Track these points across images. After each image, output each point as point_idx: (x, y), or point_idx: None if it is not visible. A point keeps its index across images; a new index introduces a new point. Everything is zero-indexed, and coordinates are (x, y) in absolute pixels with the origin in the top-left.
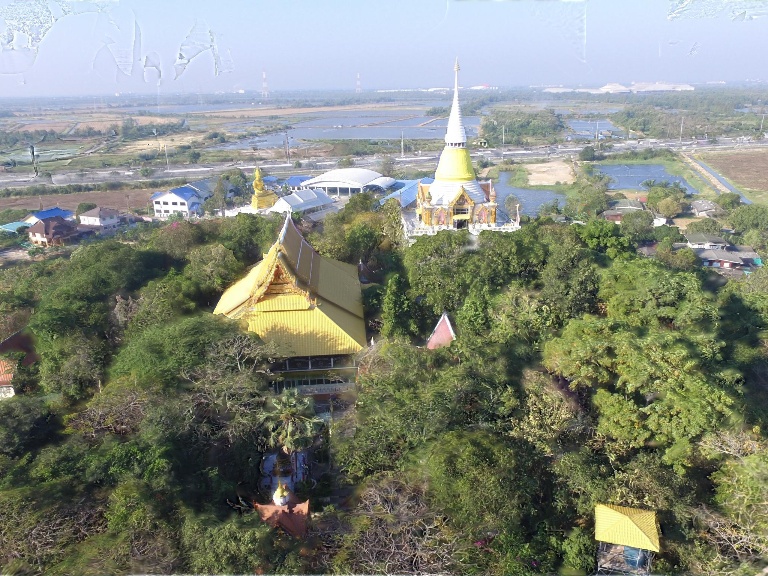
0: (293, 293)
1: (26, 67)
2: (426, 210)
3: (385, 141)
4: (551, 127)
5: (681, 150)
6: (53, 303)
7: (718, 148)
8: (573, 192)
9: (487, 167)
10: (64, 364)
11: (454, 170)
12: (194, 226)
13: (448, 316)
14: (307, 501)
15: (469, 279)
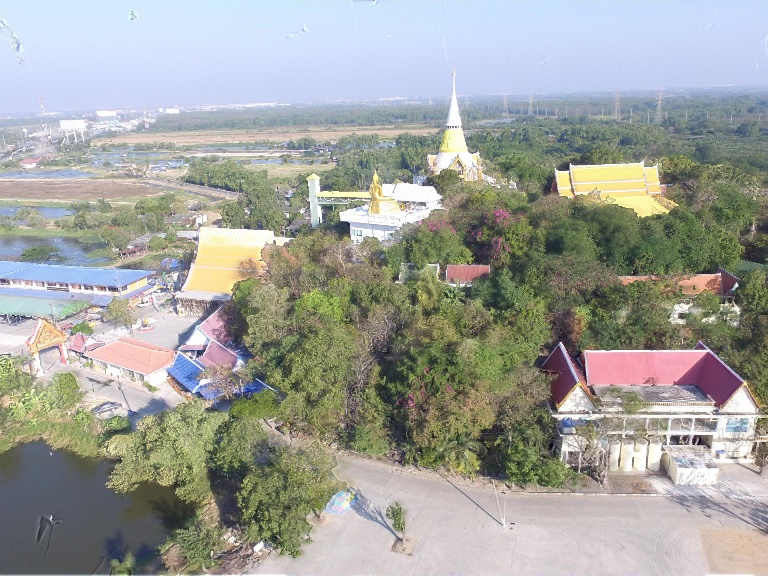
0: None
1: (320, 35)
2: None
3: None
4: None
5: None
6: None
7: None
8: (24, 232)
9: None
10: None
11: None
12: None
13: None
14: None
15: None
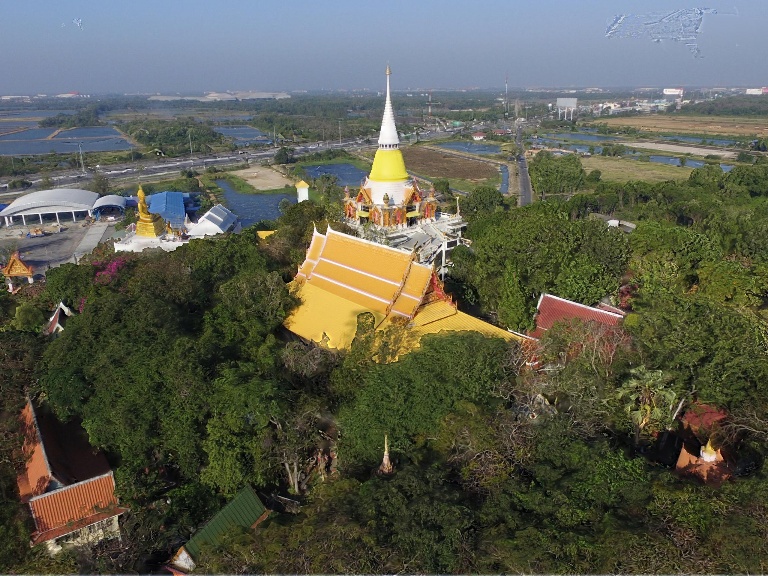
0: (436, 301)
1: None
2: (386, 211)
3: (31, 157)
4: (210, 134)
5: (350, 150)
6: (147, 382)
7: (373, 147)
8: (309, 193)
9: (193, 177)
10: (250, 446)
11: (397, 170)
12: (139, 264)
13: (550, 294)
14: (719, 450)
15: (561, 258)
